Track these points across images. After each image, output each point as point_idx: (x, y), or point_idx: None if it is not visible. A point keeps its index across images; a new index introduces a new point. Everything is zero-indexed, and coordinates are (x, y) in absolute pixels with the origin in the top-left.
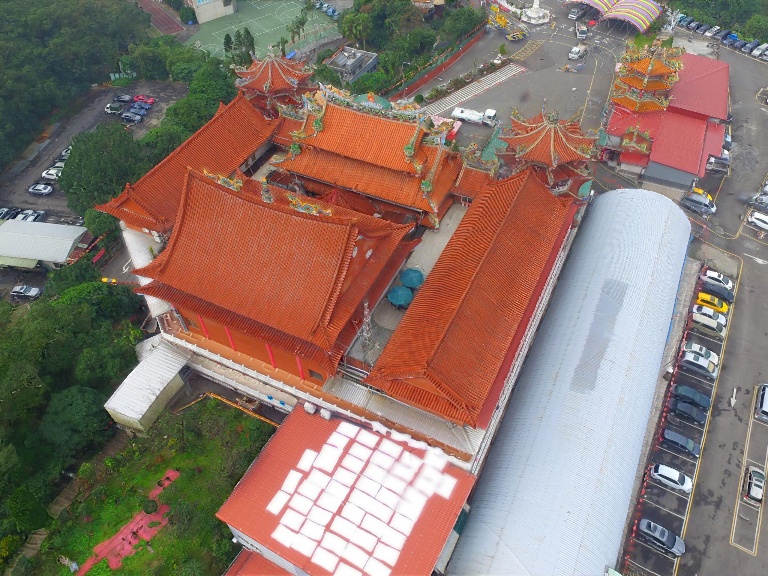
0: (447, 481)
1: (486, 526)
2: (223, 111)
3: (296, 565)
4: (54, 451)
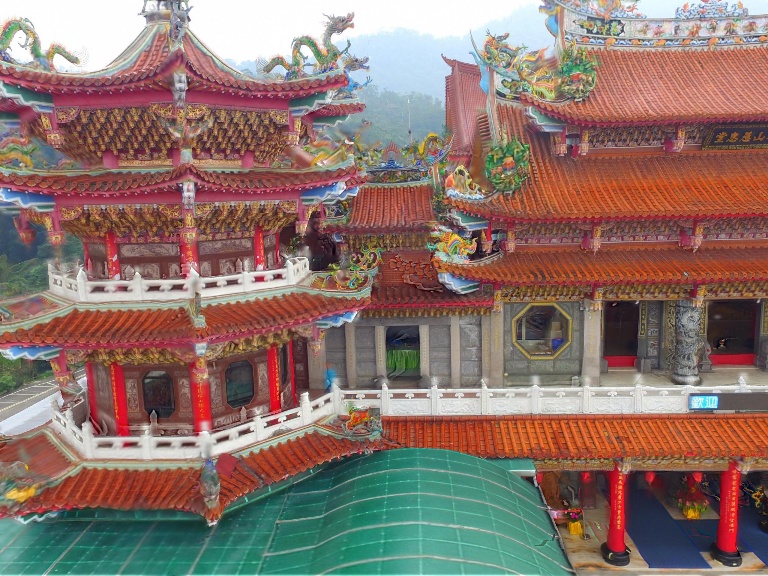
0: None
1: None
2: None
3: None
4: None
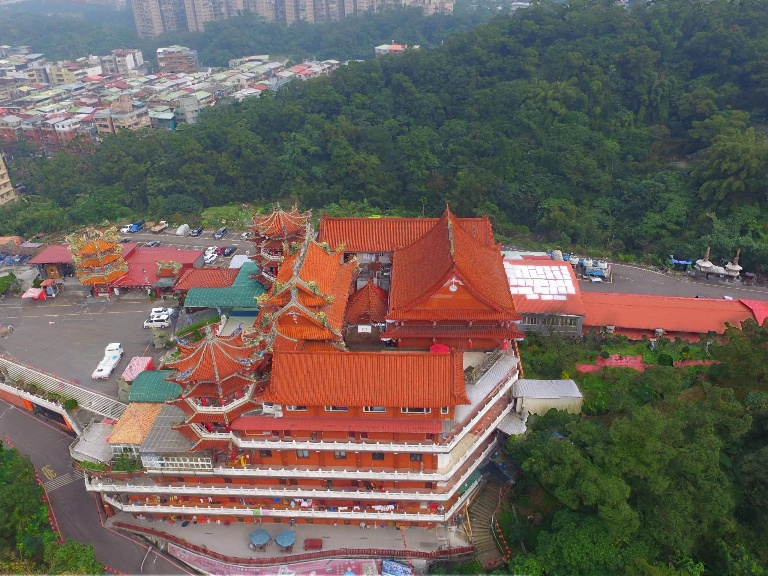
0: None
1: None
2: (309, 352)
3: None
4: None
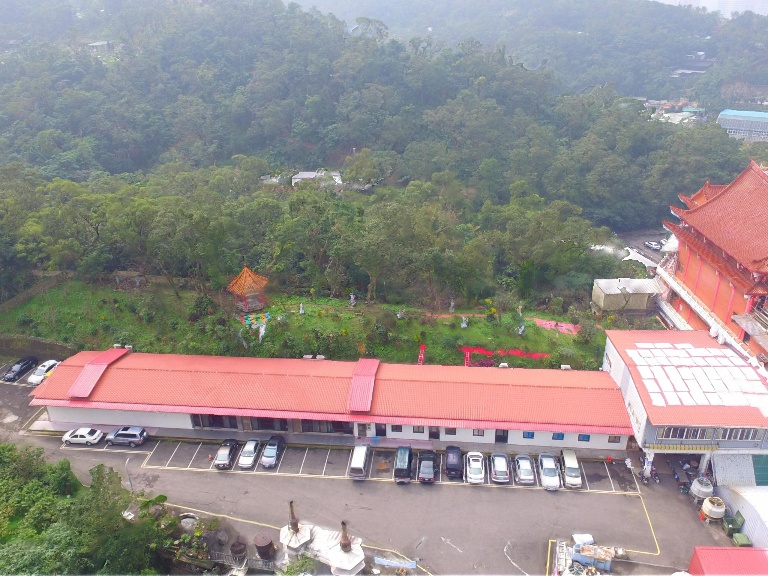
0: None
1: None
2: None
3: (626, 362)
4: (552, 290)
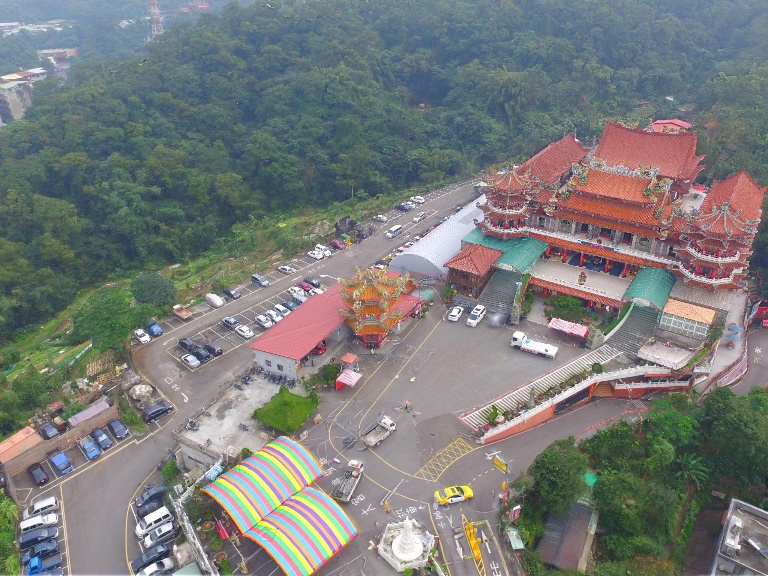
0: None
1: None
2: None
3: None
4: None
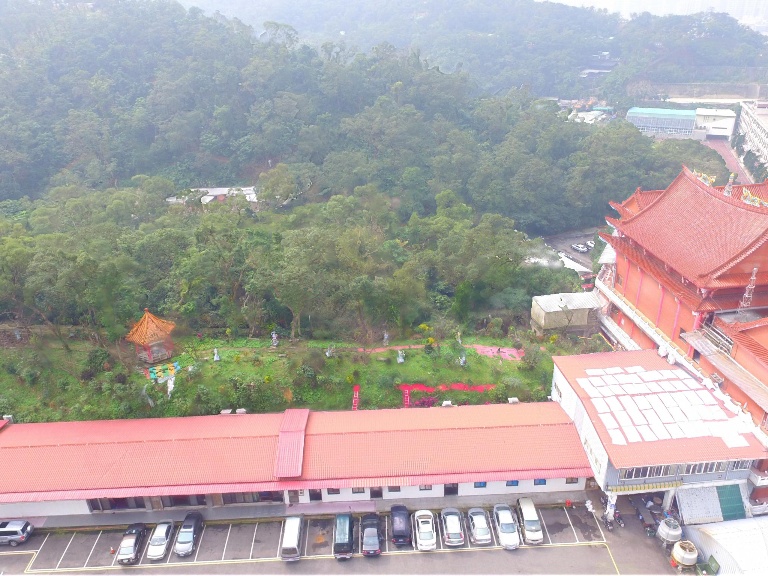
0: (739, 439)
1: (755, 520)
2: None
3: (579, 395)
4: (489, 309)
